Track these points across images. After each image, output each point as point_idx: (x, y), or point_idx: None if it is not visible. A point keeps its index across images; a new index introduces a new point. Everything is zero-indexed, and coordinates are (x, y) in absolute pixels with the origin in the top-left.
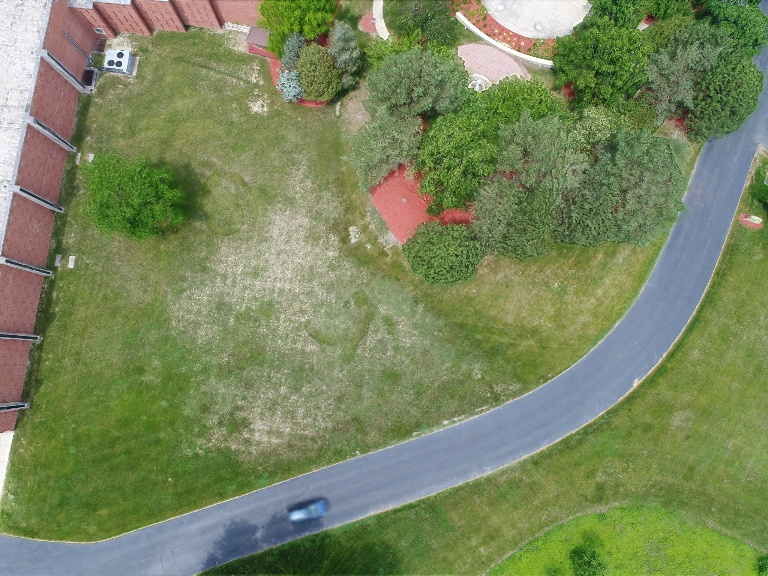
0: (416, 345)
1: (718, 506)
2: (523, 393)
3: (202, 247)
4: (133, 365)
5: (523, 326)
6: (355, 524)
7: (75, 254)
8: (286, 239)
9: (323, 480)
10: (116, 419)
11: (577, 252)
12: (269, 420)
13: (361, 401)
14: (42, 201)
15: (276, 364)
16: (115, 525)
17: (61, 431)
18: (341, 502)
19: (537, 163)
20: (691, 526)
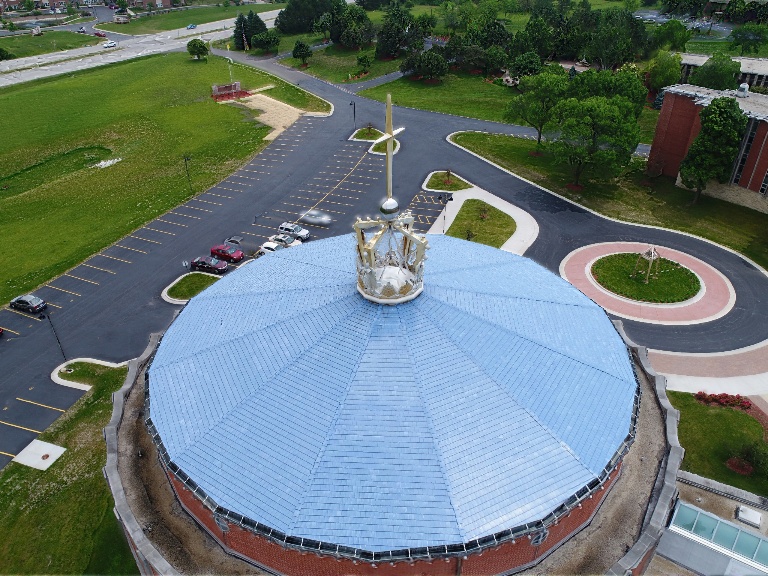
0: None
1: None
2: None
3: None
4: None
5: None
6: None
7: None
8: None
9: None
10: None
11: None
12: (688, 45)
13: None
14: None
15: None
16: None
17: None
18: None
19: None
20: None
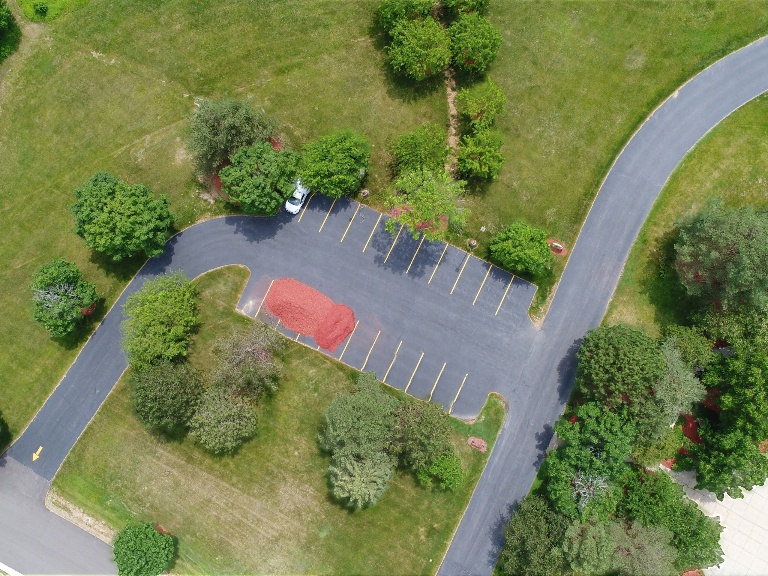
0: None
1: None
2: None
3: None
4: None
5: None
6: None
7: None
8: None
9: None
10: None
11: None
12: None
13: None
14: None
15: None
16: None
17: None
18: None
19: None
20: None
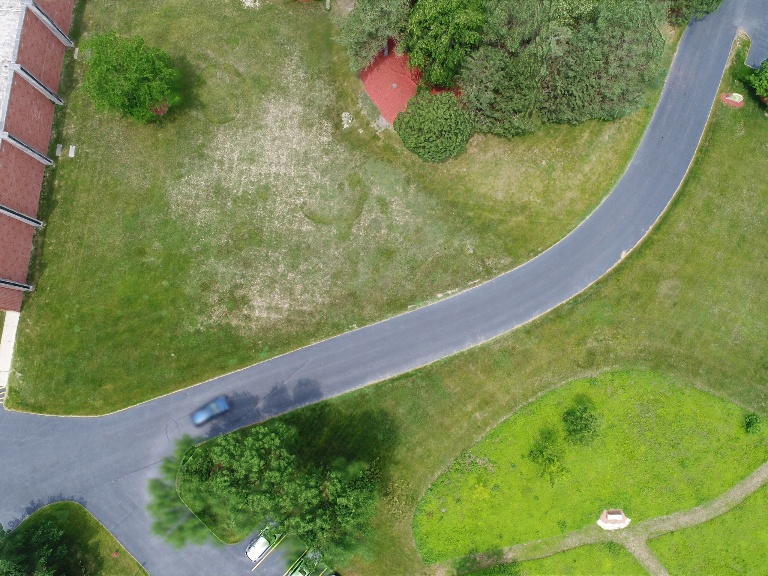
0: (409, 223)
1: (706, 368)
2: (514, 266)
3: (199, 135)
4: (134, 247)
5: (513, 202)
6: (354, 393)
7: (75, 144)
8: (280, 126)
9: (322, 352)
10: (119, 299)
11: (564, 132)
12: (268, 297)
13: (357, 277)
14: (42, 87)
15: (273, 244)
16: (120, 399)
17: (66, 311)
18: (340, 373)
19: (521, 25)
20: (680, 387)
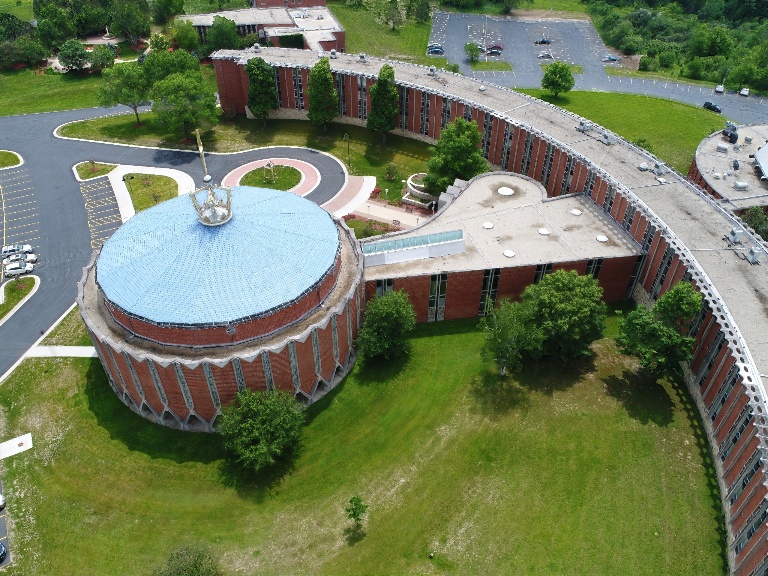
0: None
1: None
2: None
3: (204, 11)
4: None
5: None
6: None
7: None
8: None
9: None
10: None
11: None
12: None
13: None
14: None
15: None
16: None
17: None
18: None
19: None
20: None
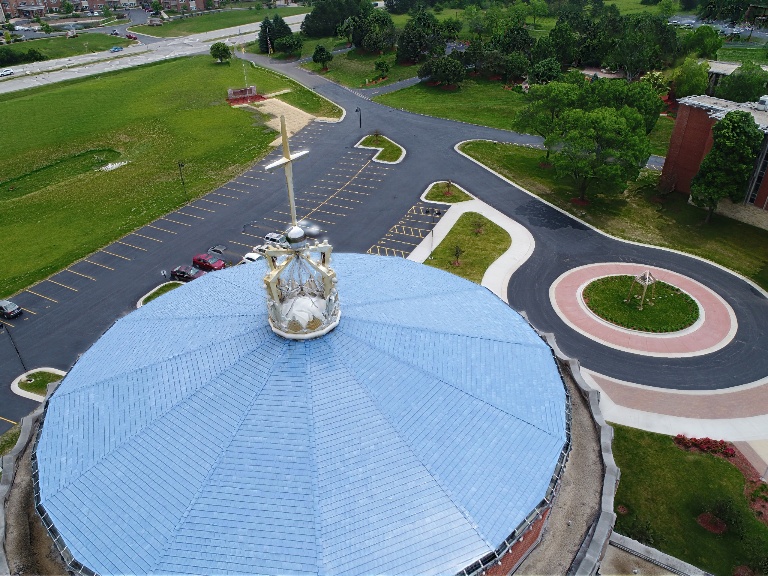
0: None
1: None
2: None
3: None
4: None
5: None
6: None
7: None
8: None
9: None
10: None
11: None
12: None
13: None
14: None
15: None
16: None
17: None
18: None
19: None
20: None
